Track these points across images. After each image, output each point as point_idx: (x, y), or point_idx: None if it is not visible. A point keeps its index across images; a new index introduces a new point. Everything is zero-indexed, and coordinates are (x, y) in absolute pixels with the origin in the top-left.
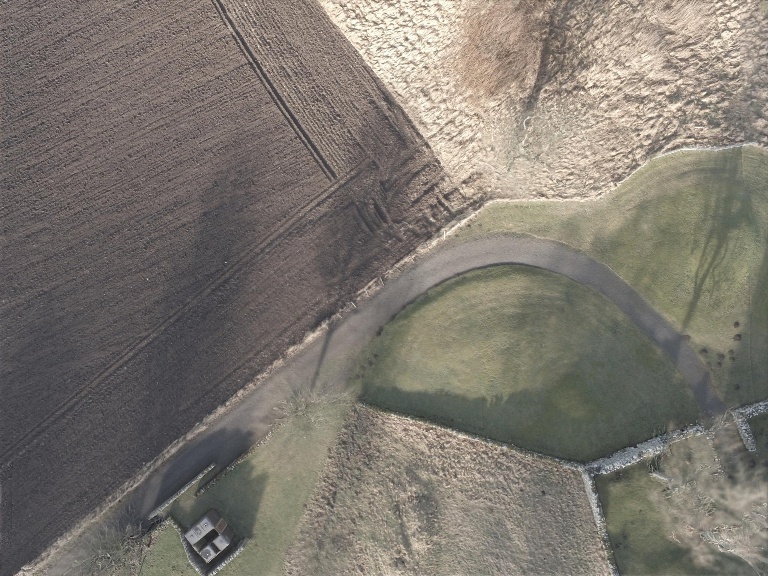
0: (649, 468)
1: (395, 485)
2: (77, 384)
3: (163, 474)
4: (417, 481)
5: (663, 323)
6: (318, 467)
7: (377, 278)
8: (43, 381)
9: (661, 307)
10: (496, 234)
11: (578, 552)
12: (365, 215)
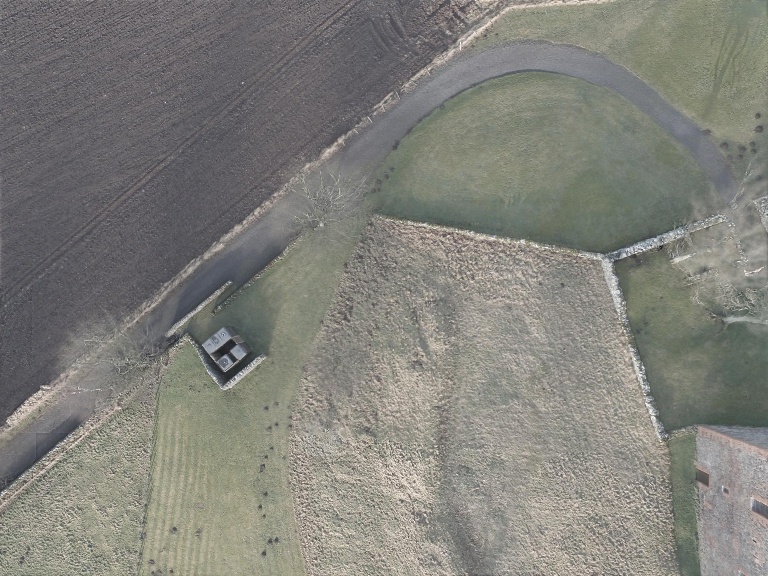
0: (670, 255)
1: (412, 293)
2: (96, 207)
3: (180, 295)
4: (434, 286)
5: (682, 120)
6: (335, 283)
7: (393, 92)
8: (62, 205)
9: (680, 104)
10: (512, 42)
11: (598, 340)
12: (381, 31)
